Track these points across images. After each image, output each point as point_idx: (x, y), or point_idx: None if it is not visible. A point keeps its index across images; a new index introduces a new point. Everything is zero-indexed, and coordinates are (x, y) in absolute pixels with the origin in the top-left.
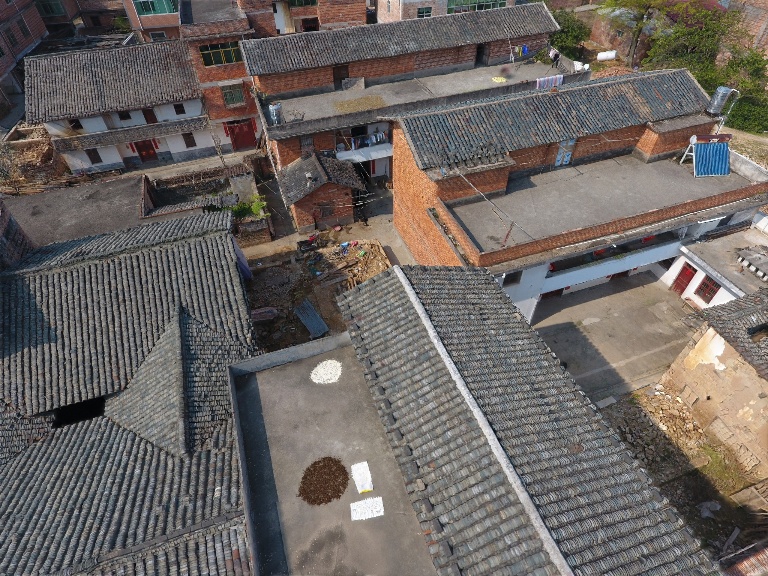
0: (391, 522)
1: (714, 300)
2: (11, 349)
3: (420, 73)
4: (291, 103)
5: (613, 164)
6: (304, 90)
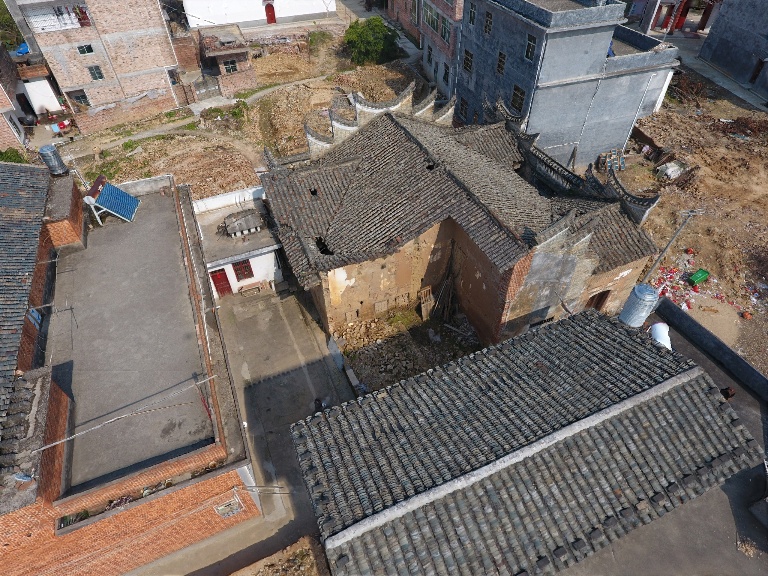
0: (628, 567)
1: (254, 270)
2: None
3: None
4: None
5: (69, 276)
6: None
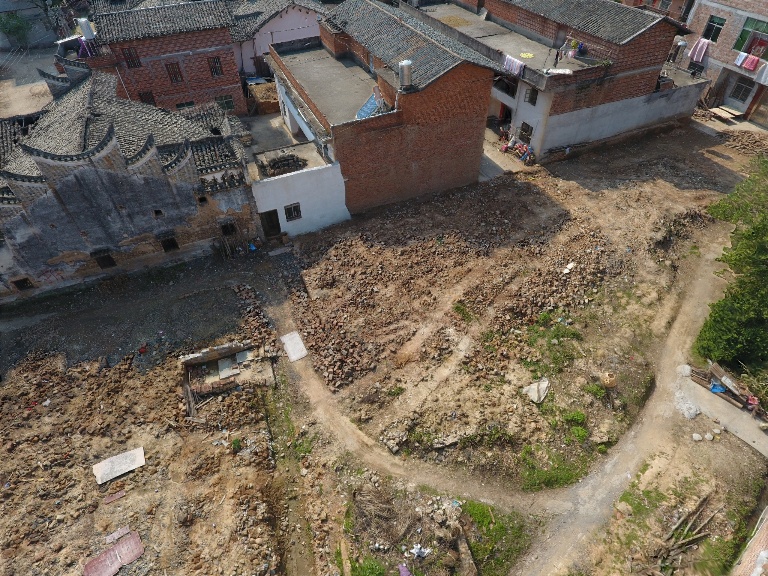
0: None
1: None
2: (250, 0)
3: (519, 29)
4: (451, 7)
5: None
6: (465, 4)
